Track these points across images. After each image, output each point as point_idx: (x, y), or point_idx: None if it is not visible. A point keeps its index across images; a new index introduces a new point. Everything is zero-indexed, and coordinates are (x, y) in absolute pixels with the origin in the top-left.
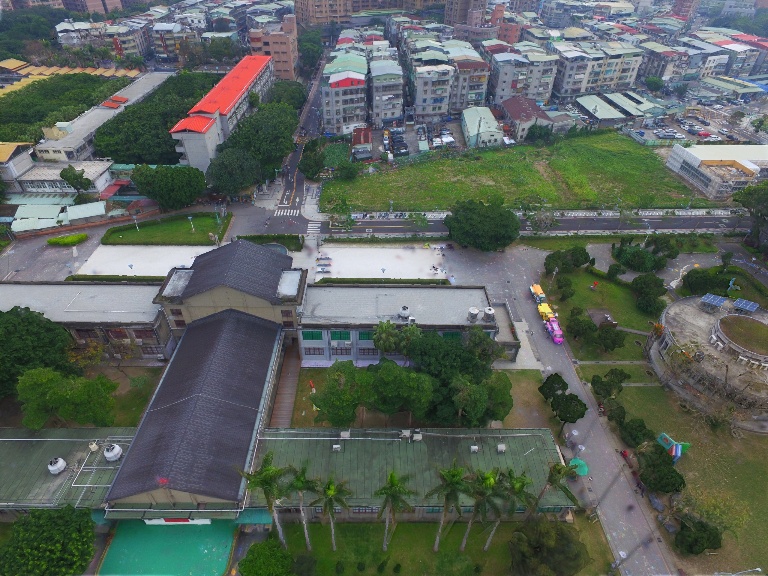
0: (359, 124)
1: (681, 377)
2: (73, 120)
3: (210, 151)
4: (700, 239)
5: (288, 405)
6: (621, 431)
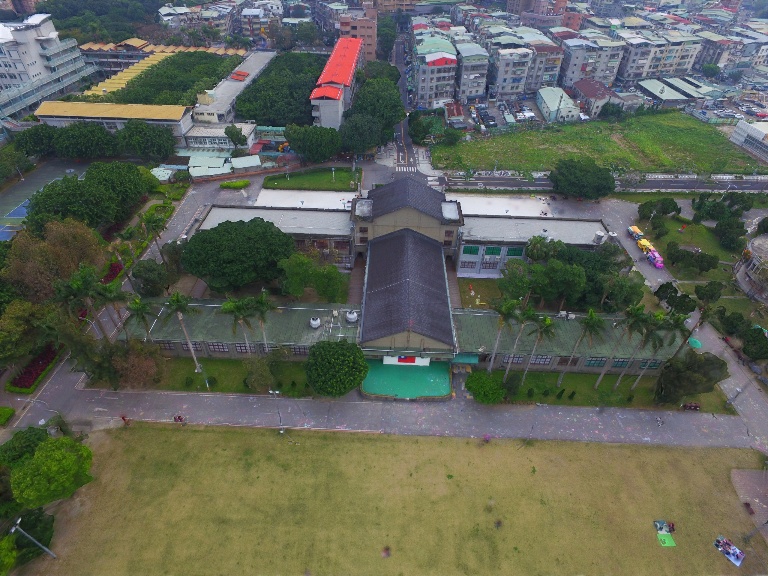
0: (447, 100)
1: (767, 290)
2: (213, 89)
3: (340, 116)
4: (767, 198)
5: (457, 300)
6: (723, 322)
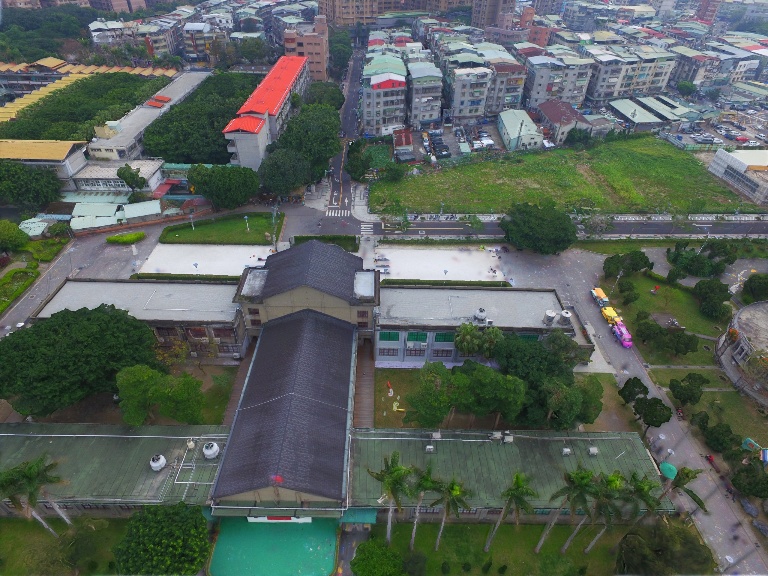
0: (398, 126)
1: (758, 382)
2: (120, 119)
3: (261, 151)
4: (753, 244)
5: (368, 405)
6: (706, 436)
